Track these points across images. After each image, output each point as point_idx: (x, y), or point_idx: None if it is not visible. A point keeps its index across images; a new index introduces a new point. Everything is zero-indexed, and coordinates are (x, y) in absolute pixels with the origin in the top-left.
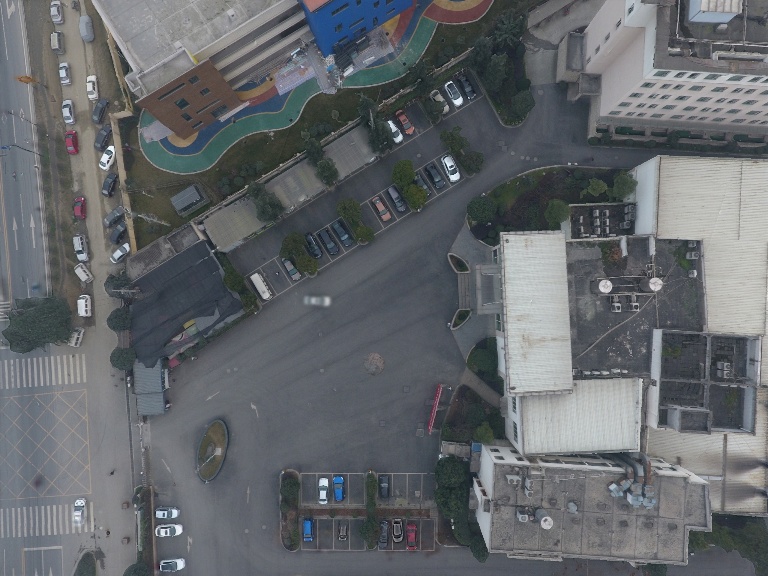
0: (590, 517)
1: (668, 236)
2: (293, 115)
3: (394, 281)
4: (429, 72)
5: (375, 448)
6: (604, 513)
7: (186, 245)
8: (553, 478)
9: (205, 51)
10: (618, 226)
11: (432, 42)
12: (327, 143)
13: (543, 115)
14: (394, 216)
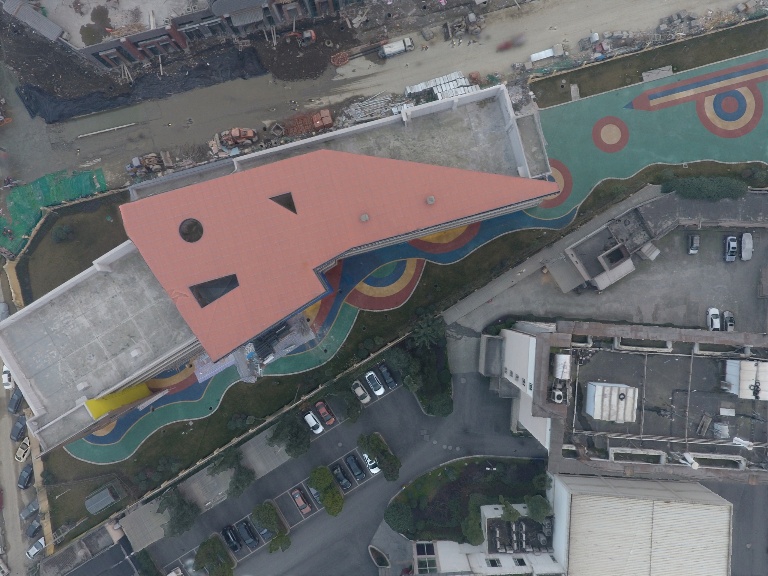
0: None
1: (579, 575)
2: (212, 404)
3: (314, 573)
4: (350, 361)
5: None
6: None
7: (101, 546)
8: None
9: (109, 391)
10: (536, 536)
11: (353, 329)
12: (246, 436)
13: (465, 404)
14: (315, 506)
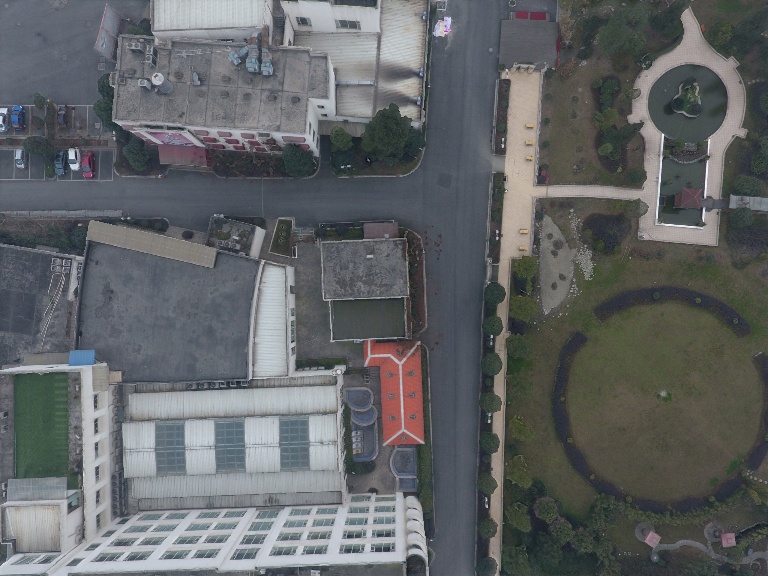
0: (215, 90)
1: None
2: None
3: None
4: None
5: (57, 81)
6: (229, 87)
7: None
8: (180, 53)
9: None
10: None
11: None
12: None
13: None
14: None
